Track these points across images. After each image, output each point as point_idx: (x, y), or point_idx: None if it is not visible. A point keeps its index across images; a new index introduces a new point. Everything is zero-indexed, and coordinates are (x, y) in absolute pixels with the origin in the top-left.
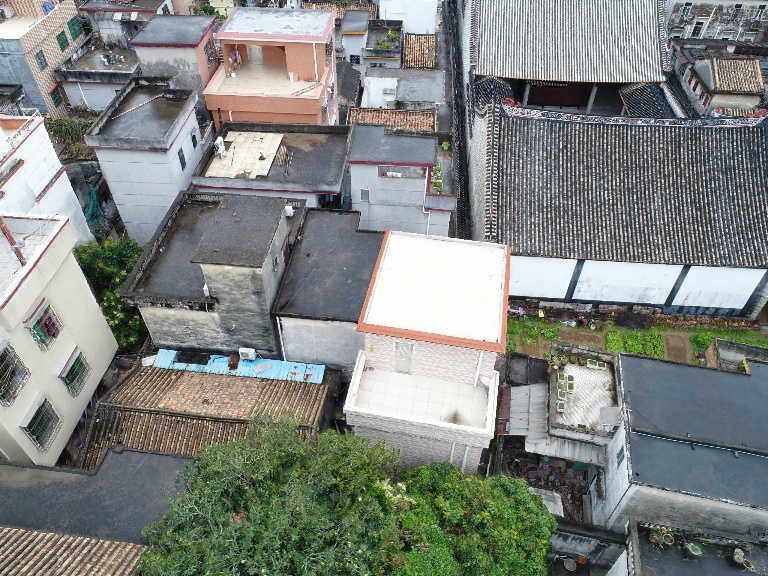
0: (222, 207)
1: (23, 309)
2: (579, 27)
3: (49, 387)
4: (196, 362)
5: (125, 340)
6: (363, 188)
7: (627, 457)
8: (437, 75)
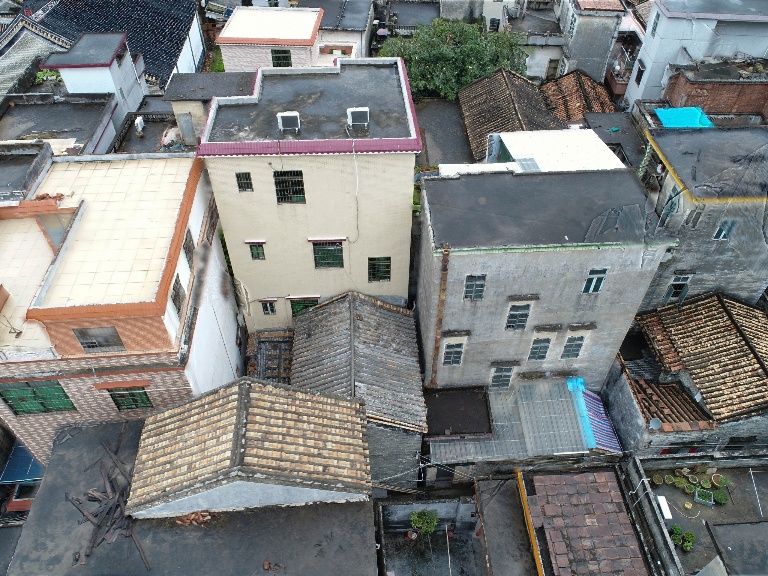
0: (182, 96)
1: None
2: None
3: None
4: None
5: None
6: (119, 87)
7: (353, 29)
8: None
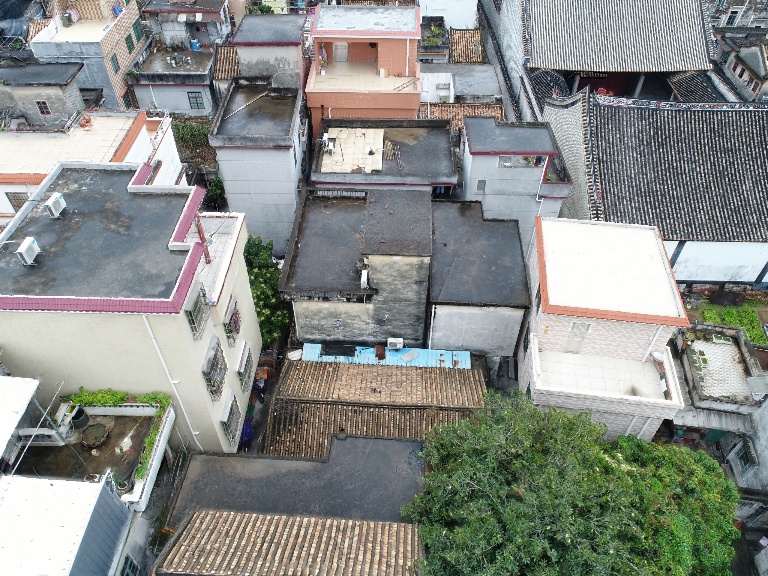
0: (371, 200)
1: (225, 305)
2: (626, 19)
3: (233, 382)
4: (343, 354)
5: (268, 336)
6: (481, 179)
7: None
8: (489, 69)
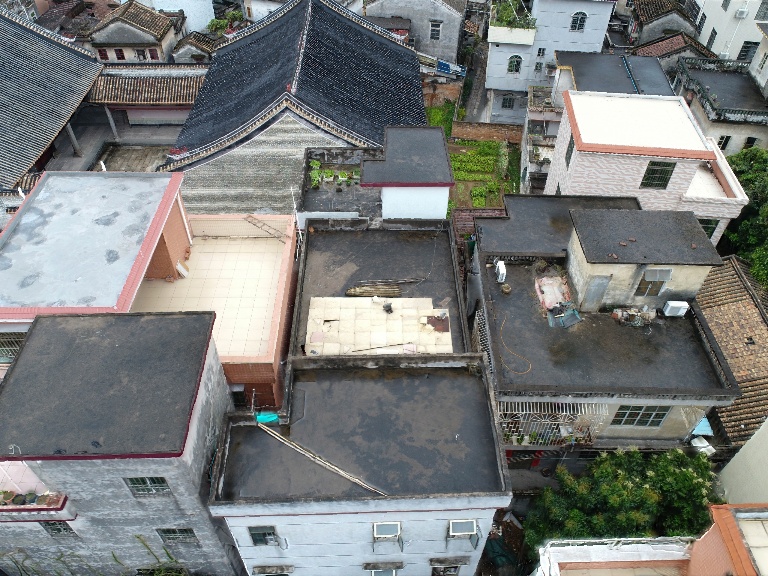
0: (616, 256)
1: None
2: None
3: None
4: None
5: None
6: None
7: None
8: None
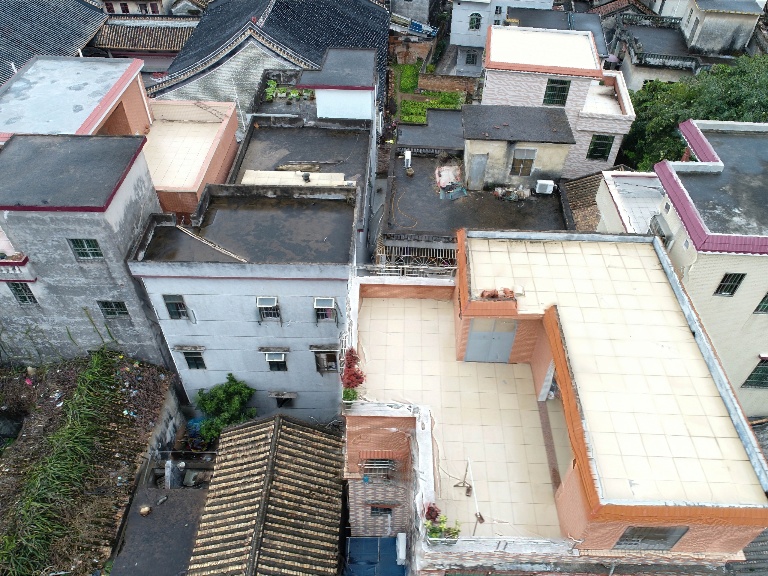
0: (488, 135)
1: None
2: (1, 15)
3: None
4: None
5: None
6: None
7: None
8: None
